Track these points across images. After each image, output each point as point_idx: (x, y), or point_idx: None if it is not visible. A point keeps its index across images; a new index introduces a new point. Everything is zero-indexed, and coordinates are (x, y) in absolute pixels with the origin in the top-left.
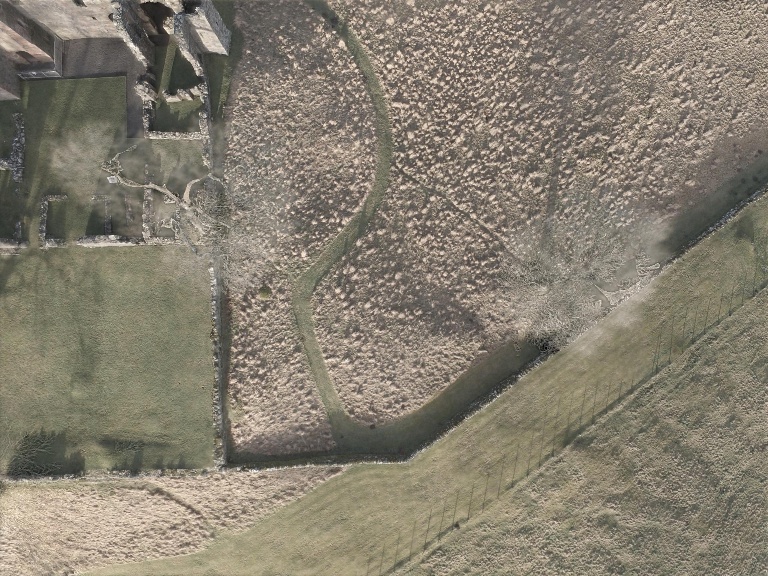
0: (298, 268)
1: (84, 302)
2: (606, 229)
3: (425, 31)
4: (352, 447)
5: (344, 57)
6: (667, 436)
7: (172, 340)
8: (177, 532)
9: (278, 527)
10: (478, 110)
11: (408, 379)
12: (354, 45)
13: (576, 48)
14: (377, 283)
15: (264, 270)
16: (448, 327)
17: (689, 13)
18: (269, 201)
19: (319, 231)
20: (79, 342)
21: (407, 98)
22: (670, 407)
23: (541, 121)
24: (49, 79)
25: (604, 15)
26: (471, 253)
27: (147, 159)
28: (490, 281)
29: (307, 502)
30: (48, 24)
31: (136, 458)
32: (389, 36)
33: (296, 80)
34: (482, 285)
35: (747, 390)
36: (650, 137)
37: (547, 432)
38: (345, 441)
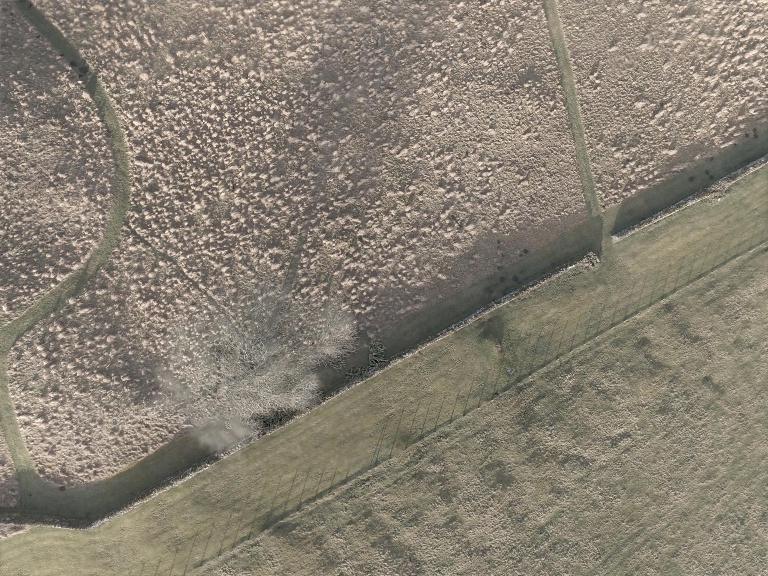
0: None
1: None
2: (344, 314)
3: (181, 90)
4: (39, 506)
5: (87, 108)
6: (378, 531)
7: None
8: None
9: None
10: (225, 178)
11: (104, 445)
12: (101, 97)
13: (340, 125)
14: (86, 344)
15: None
16: (154, 397)
17: (467, 102)
18: None
19: (29, 285)
20: None
21: (152, 157)
22: (386, 502)
23: (291, 196)
24: None
25: (375, 95)
26: (194, 323)
27: None
28: (208, 355)
29: None
30: None
31: None
32: (141, 92)
33: (25, 128)
34: (198, 358)
35: (472, 493)
36: (407, 224)
37: (247, 514)
38: (33, 499)
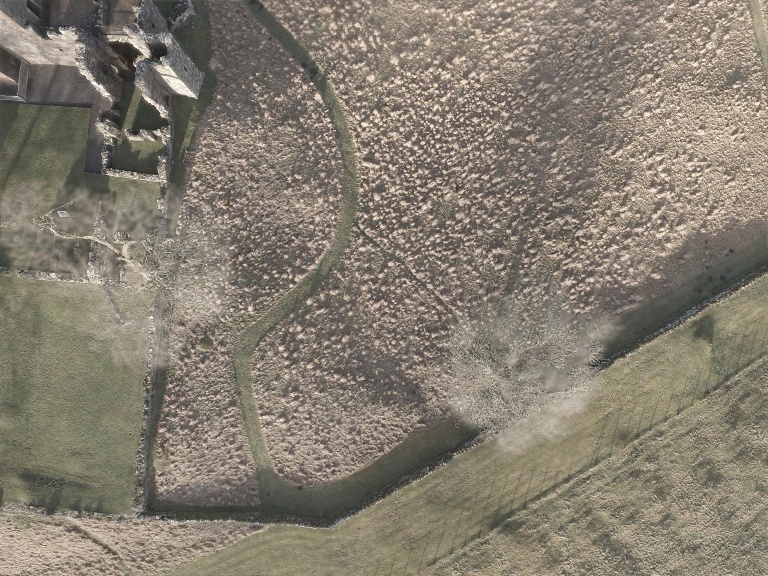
0: (243, 322)
1: (21, 332)
2: (564, 314)
3: (405, 92)
4: (277, 506)
5: (319, 110)
6: (598, 529)
7: (105, 382)
8: (92, 569)
9: (194, 575)
10: (449, 179)
11: (342, 444)
12: (331, 99)
13: (557, 126)
14: (323, 344)
15: (208, 321)
16: (389, 397)
17: (677, 103)
18: (222, 251)
19: (270, 286)
20: (12, 372)
21: (378, 158)
22: (605, 500)
23: (512, 197)
24: (12, 102)
25: (590, 96)
26: (423, 324)
27: (102, 195)
28: (438, 354)
29: (226, 555)
30: (14, 49)
31: (55, 496)
32: (368, 93)
33: (265, 130)
34: (429, 358)
35: (685, 491)
36: (621, 225)
37: (476, 512)
38: (271, 499)
